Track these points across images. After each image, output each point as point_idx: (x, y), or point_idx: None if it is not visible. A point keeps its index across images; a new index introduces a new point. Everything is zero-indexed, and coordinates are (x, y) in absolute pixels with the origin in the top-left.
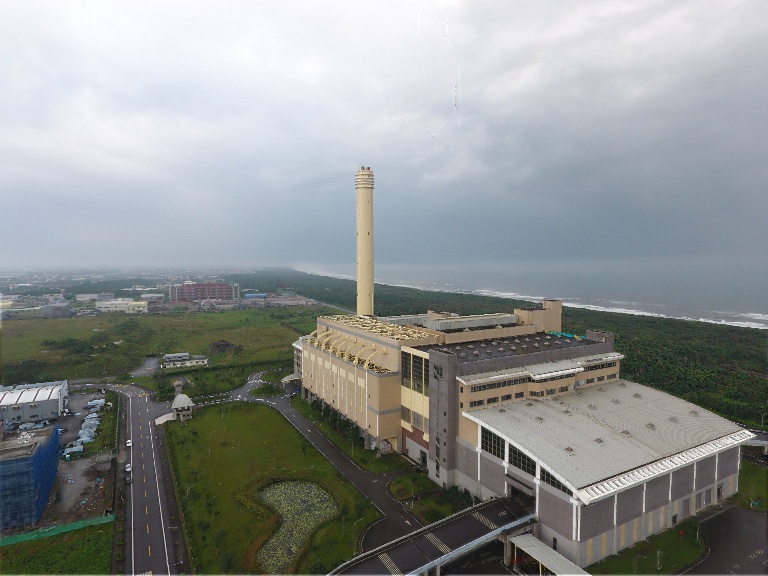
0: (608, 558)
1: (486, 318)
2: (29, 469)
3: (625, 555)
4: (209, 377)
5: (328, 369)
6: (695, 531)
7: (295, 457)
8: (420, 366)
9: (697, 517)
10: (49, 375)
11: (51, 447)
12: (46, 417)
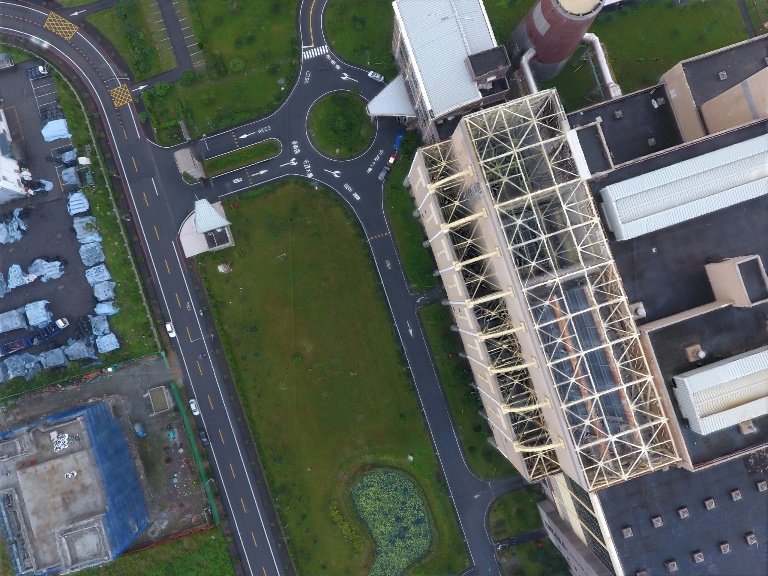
0: None
1: None
2: None
3: None
4: (220, 5)
5: (457, 291)
6: None
7: (390, 417)
8: (596, 534)
9: None
10: None
11: (101, 451)
12: (7, 199)
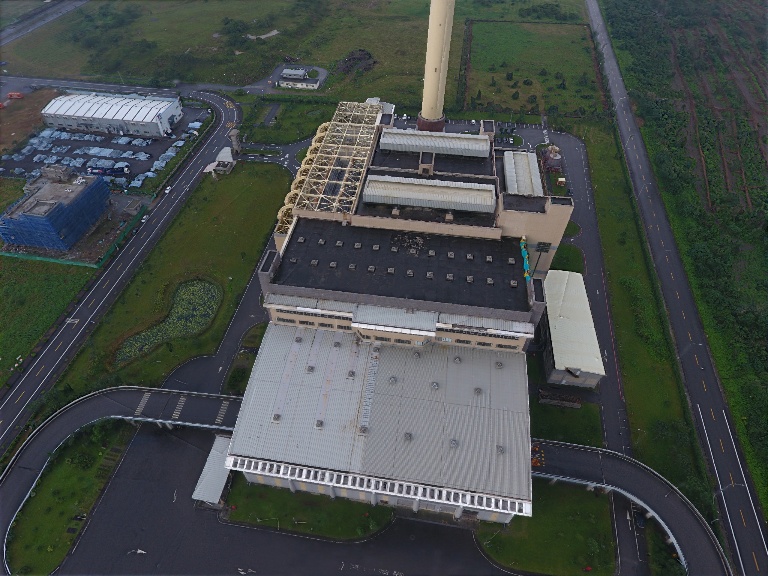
0: (283, 489)
1: (439, 199)
2: (47, 223)
3: (297, 496)
4: (295, 114)
5: None
6: (369, 524)
7: (237, 259)
8: None
9: (414, 513)
10: (193, 76)
11: (89, 195)
12: (154, 134)
